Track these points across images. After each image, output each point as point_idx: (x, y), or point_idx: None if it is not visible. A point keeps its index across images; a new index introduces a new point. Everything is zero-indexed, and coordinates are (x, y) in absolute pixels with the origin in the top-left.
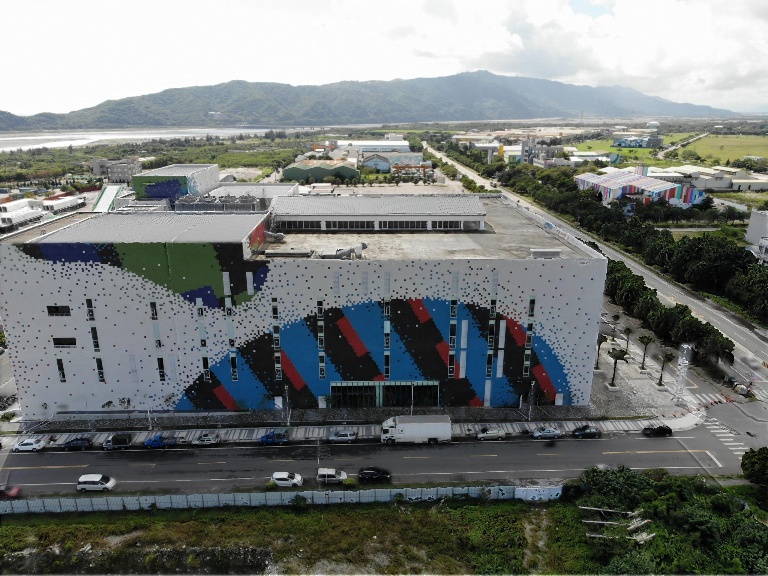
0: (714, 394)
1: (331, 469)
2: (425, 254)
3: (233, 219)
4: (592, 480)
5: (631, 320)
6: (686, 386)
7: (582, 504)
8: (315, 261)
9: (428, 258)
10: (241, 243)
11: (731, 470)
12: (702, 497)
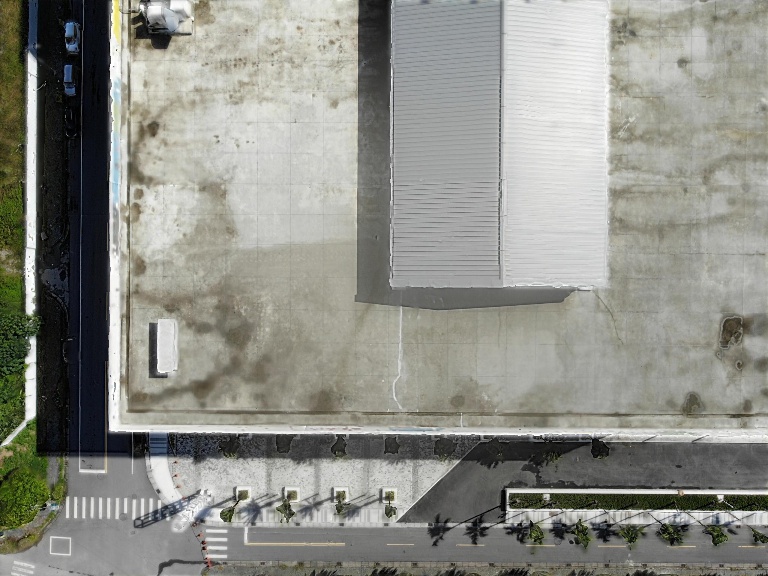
0: (225, 553)
1: (70, 77)
2: (194, 138)
3: None
4: (8, 316)
5: (487, 568)
6: (249, 530)
7: (1, 302)
8: None
9: (168, 141)
10: None
11: (74, 477)
12: (6, 414)
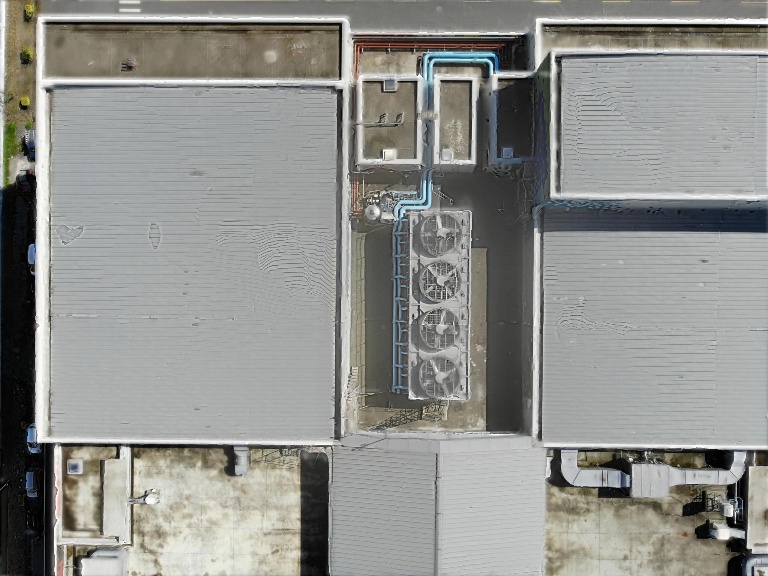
0: None
1: (32, 484)
2: None
3: (265, 377)
4: None
5: None
6: None
7: None
8: (56, 547)
9: None
10: (38, 440)
11: None
12: None
